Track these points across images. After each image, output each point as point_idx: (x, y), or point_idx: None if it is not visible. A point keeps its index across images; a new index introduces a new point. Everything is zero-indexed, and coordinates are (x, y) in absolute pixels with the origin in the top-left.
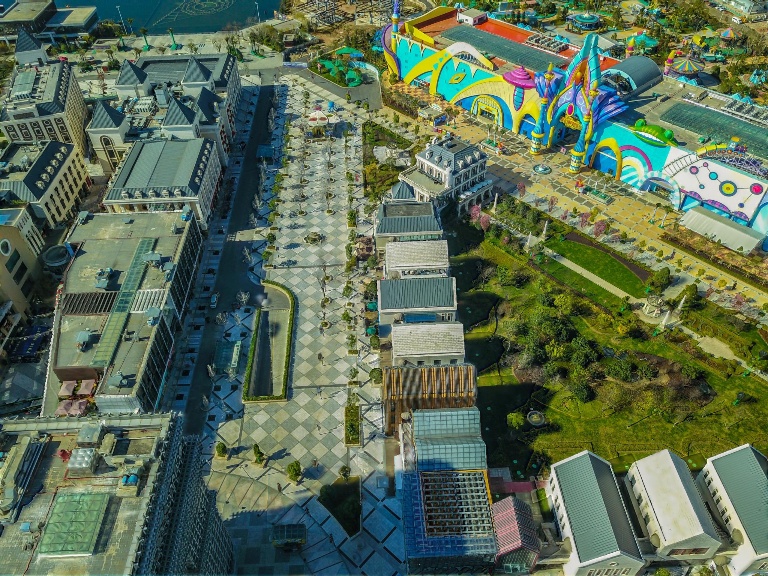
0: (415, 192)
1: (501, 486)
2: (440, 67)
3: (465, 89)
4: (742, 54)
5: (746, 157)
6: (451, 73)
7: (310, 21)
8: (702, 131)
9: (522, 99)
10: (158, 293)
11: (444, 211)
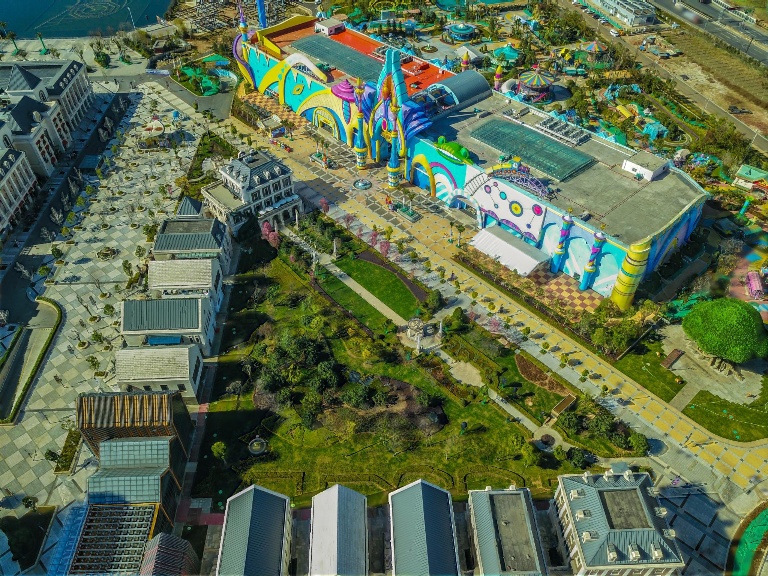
0: (215, 207)
1: (197, 518)
2: (283, 78)
3: (305, 101)
4: (597, 68)
5: (530, 177)
6: (293, 84)
7: (186, 27)
8: (505, 149)
9: (349, 112)
10: None
11: (244, 227)
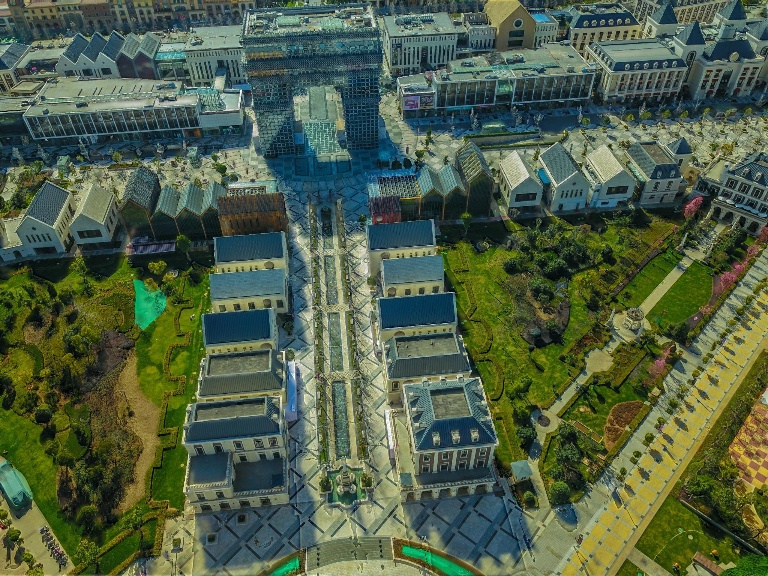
0: None
1: None
2: None
3: None
4: None
5: None
6: None
7: None
8: None
9: None
10: (512, 75)
11: None
